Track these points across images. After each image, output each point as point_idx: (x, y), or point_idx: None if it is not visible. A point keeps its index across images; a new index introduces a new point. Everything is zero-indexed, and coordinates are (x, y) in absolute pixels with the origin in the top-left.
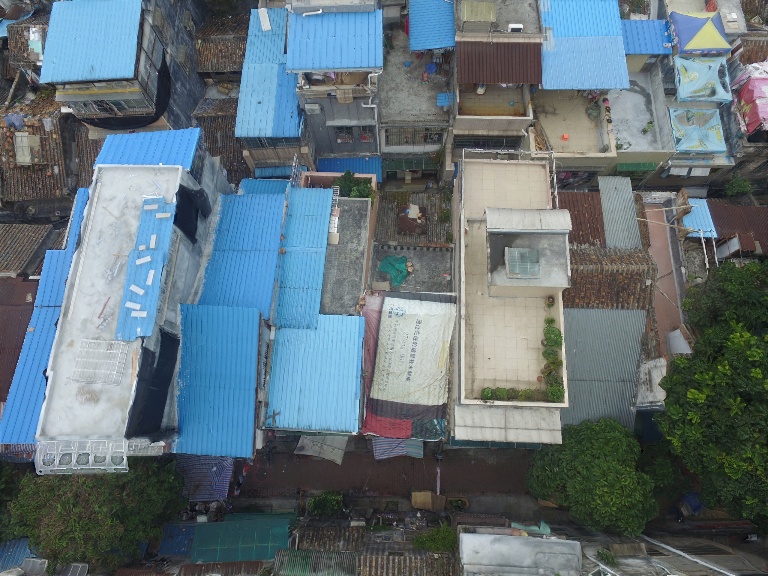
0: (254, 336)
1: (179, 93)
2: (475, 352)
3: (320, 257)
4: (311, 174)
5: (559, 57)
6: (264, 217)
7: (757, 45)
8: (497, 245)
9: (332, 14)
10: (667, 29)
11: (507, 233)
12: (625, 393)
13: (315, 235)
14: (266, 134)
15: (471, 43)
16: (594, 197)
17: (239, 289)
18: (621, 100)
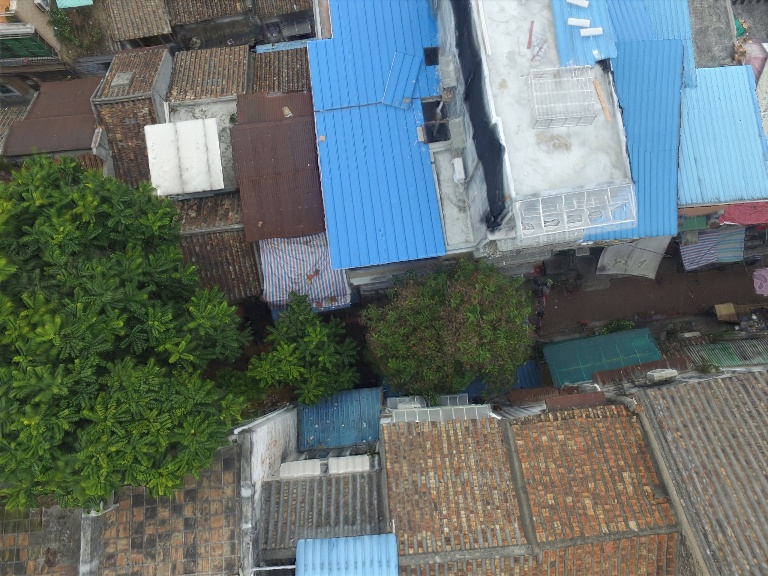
0: (677, 78)
1: None
2: None
3: None
4: None
5: None
6: None
7: None
8: None
9: None
10: None
11: None
12: None
13: None
14: None
15: None
16: None
17: None
18: None
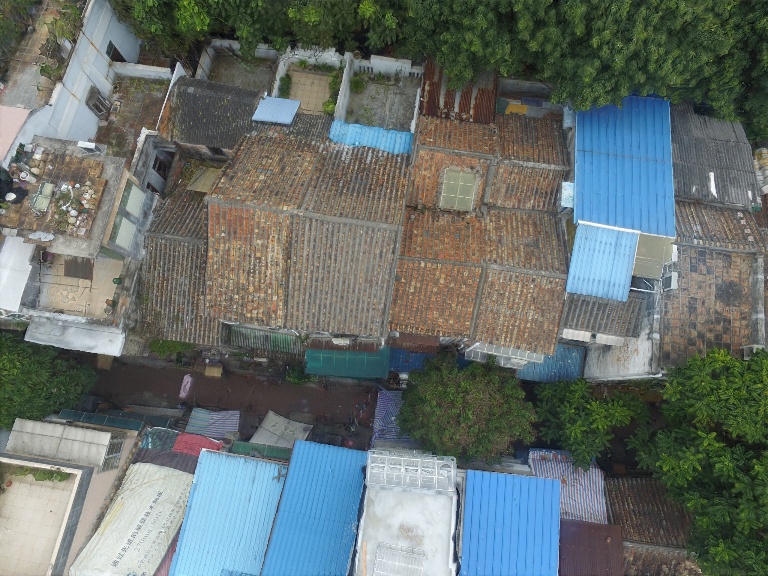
0: (265, 575)
1: None
2: None
3: None
4: None
5: None
6: None
7: None
8: None
9: None
10: None
11: None
12: None
13: None
14: None
15: None
16: None
17: None
18: None
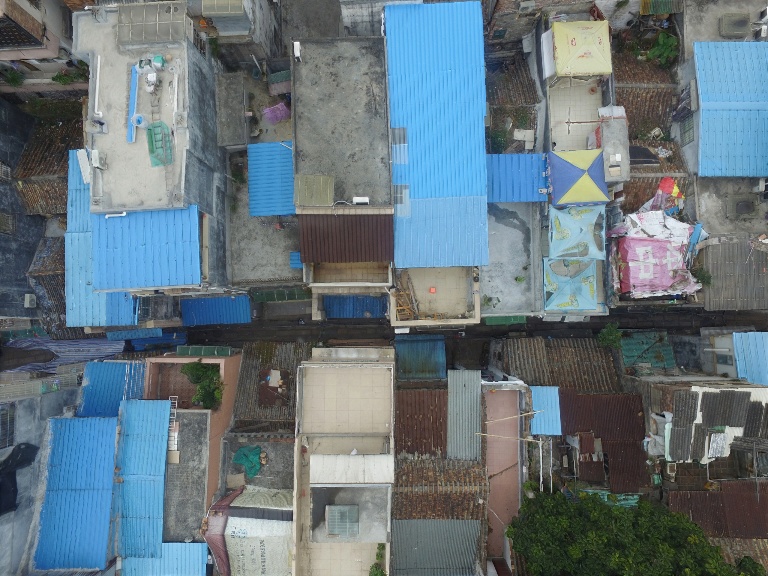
0: None
1: (1, 266)
2: (312, 575)
3: (158, 485)
4: (156, 361)
5: (414, 225)
6: (96, 448)
7: (645, 182)
8: (320, 499)
9: (139, 214)
10: (545, 169)
11: (330, 487)
12: (465, 575)
13: (152, 460)
14: (100, 323)
15: (314, 215)
16: (441, 397)
17: (75, 536)
18: (497, 238)
